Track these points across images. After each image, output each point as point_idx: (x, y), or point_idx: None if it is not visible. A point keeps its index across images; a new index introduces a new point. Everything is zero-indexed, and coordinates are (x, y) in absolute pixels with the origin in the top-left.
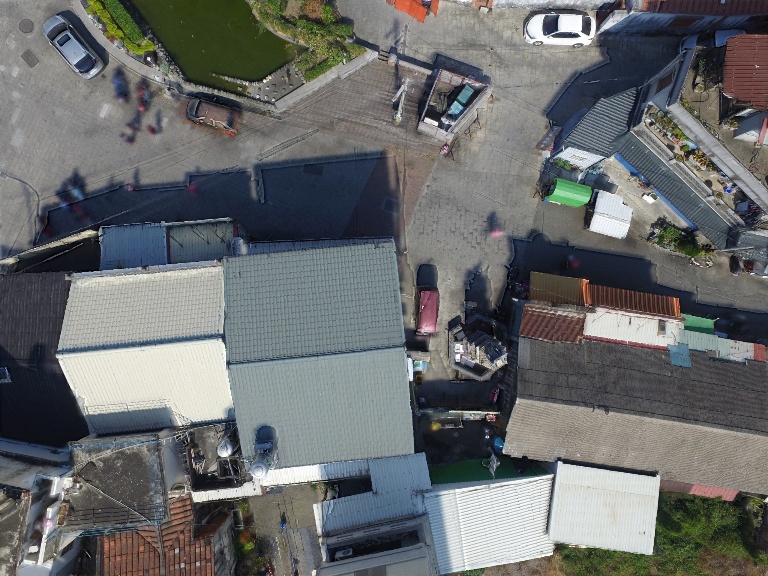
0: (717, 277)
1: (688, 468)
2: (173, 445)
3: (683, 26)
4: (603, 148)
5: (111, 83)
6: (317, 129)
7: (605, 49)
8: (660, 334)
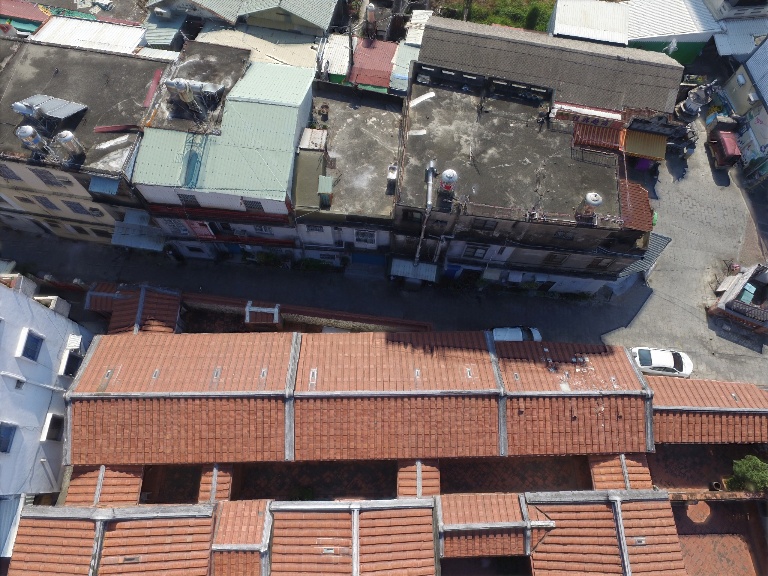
0: None
1: None
2: None
3: None
4: None
5: None
6: None
7: None
8: None
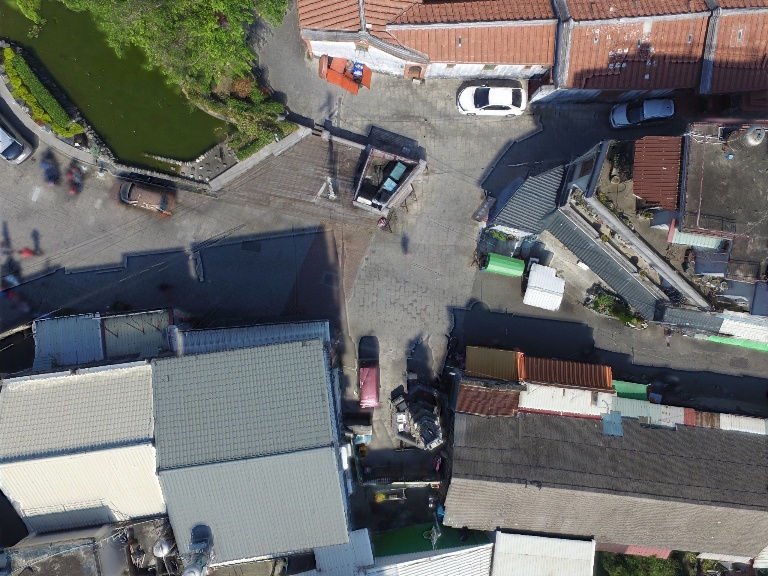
0: (652, 338)
1: (622, 532)
2: (112, 541)
3: (612, 96)
4: (532, 226)
5: (42, 166)
6: (244, 224)
7: (538, 117)
8: (593, 404)
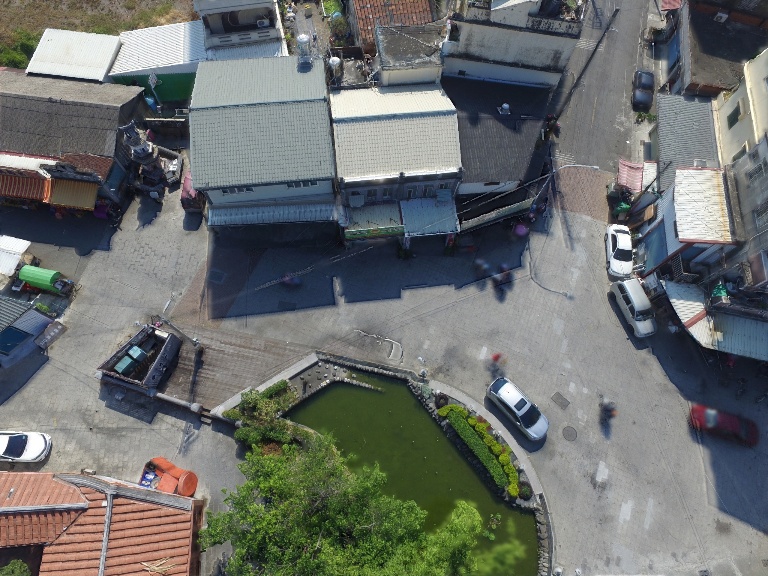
0: None
1: (1, 76)
2: None
3: None
4: None
5: (480, 379)
6: None
7: None
8: None
